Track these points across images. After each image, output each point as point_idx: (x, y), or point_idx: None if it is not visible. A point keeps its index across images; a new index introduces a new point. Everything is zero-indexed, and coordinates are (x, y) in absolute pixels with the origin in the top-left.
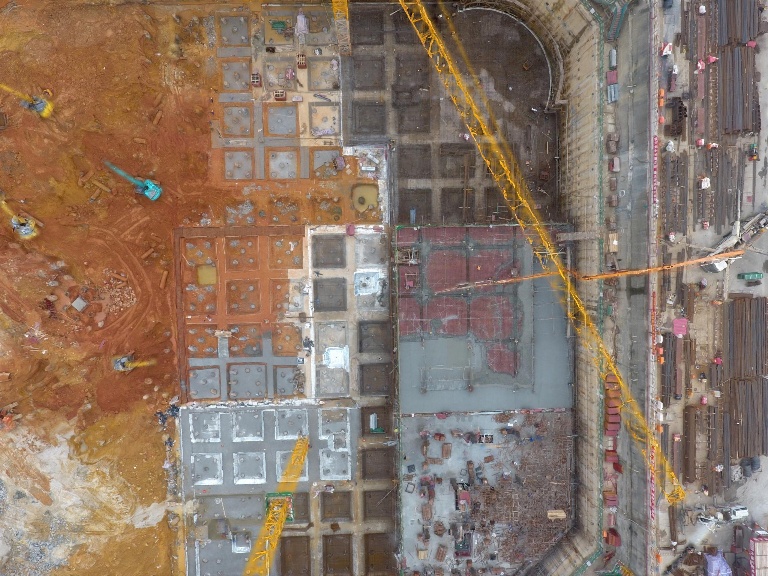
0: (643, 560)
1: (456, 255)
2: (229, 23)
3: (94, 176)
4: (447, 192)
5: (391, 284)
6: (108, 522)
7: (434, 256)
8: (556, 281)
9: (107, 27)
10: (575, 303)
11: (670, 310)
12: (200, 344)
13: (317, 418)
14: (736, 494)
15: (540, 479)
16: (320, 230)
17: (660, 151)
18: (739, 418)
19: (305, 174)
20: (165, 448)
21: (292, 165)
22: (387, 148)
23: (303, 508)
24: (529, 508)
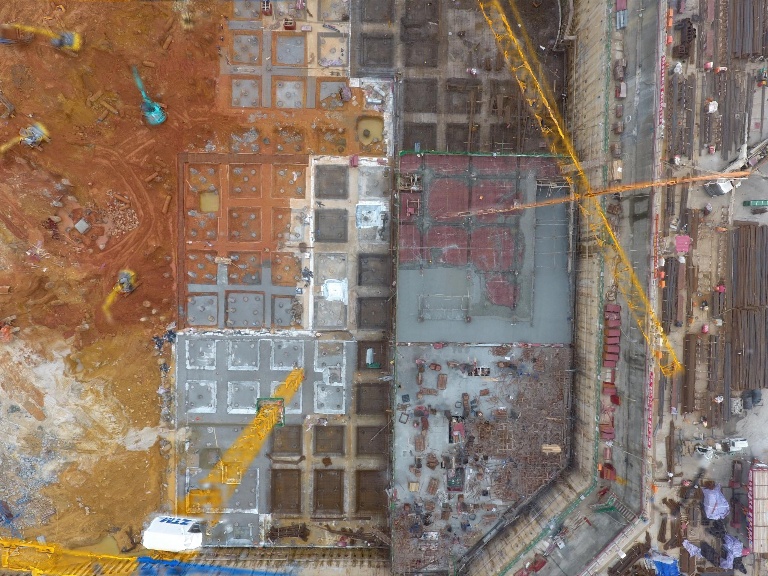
0: (638, 491)
1: (459, 184)
2: None
3: (102, 97)
4: (452, 127)
5: None
6: (100, 441)
7: (436, 184)
8: (559, 216)
9: None
10: (577, 237)
11: (673, 235)
12: (200, 271)
13: (313, 350)
14: (736, 428)
15: (536, 412)
16: (324, 160)
17: (668, 73)
18: (741, 348)
19: (311, 104)
20: (160, 374)
21: (299, 95)
22: (394, 81)
23: (295, 441)
24: (524, 444)
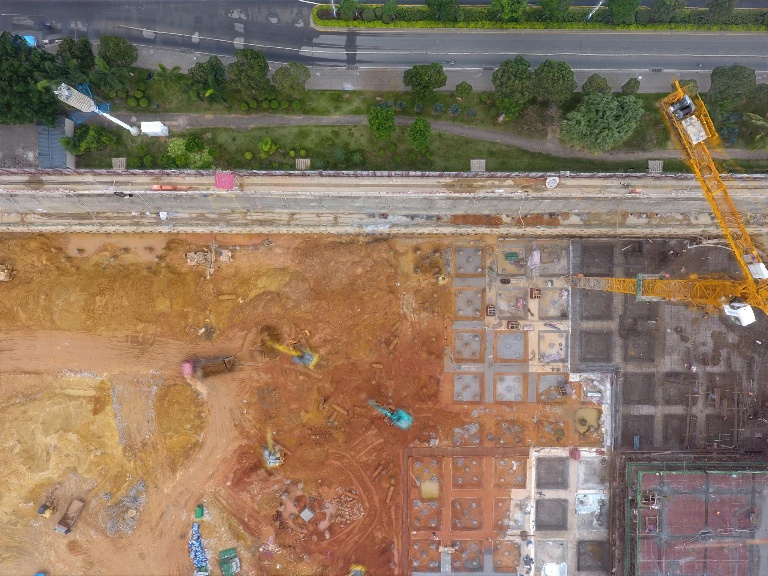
0: None
1: (695, 499)
2: (464, 253)
3: (334, 401)
4: (670, 419)
5: (612, 507)
6: None
7: (674, 500)
8: None
9: (358, 266)
10: None
11: None
12: (422, 557)
13: None
14: None
15: None
16: (544, 452)
17: None
18: None
19: (532, 398)
20: None
21: (518, 388)
22: (613, 376)
23: None
24: None
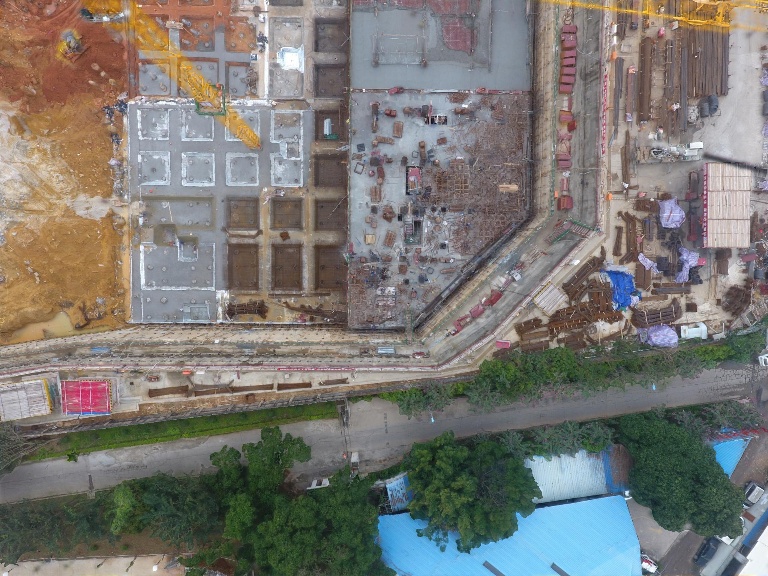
0: (593, 206)
1: None
2: None
3: None
4: None
5: None
6: (48, 202)
7: None
8: None
9: None
10: None
11: None
12: (151, 38)
13: (269, 119)
14: (692, 139)
15: (493, 153)
16: None
17: None
18: (697, 50)
19: None
20: (112, 146)
21: None
22: None
23: (253, 217)
24: (482, 196)
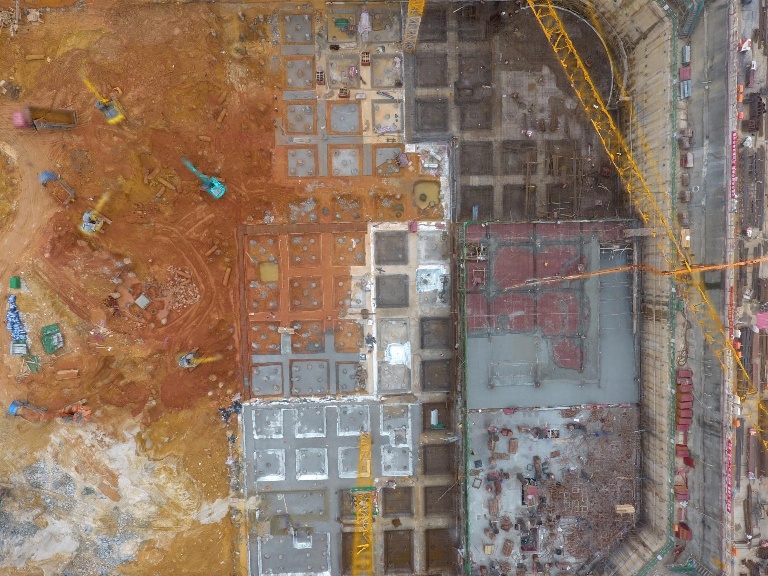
0: (717, 554)
1: (523, 251)
2: (292, 21)
3: (160, 174)
4: (509, 189)
5: (453, 280)
6: (175, 518)
7: (501, 252)
8: (621, 277)
9: (174, 25)
10: (641, 299)
11: (746, 305)
12: (263, 341)
13: (379, 414)
14: None
15: (608, 474)
16: (382, 227)
17: (737, 147)
18: None
19: (368, 171)
20: (228, 444)
21: (354, 162)
22: (450, 145)
23: None
24: (595, 503)
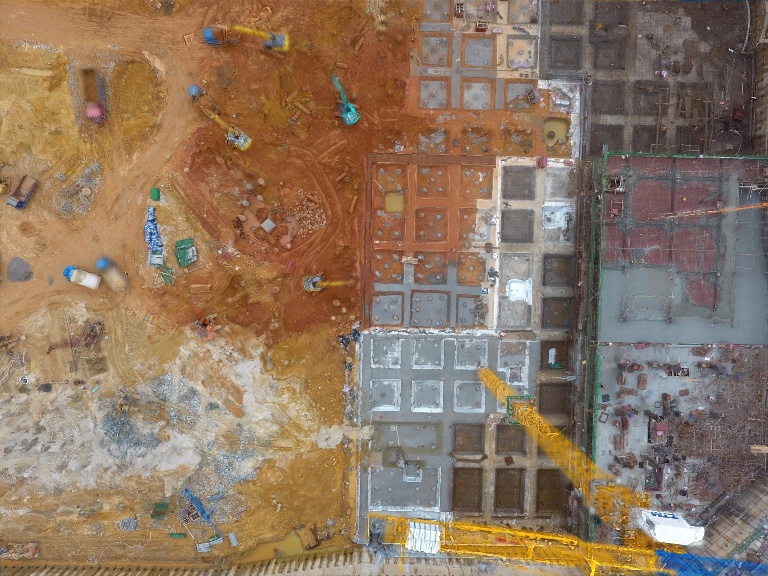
0: None
1: (662, 185)
2: None
3: (297, 97)
4: (640, 129)
5: (579, 218)
6: (295, 439)
7: (640, 185)
8: (756, 218)
9: None
10: None
11: None
12: (385, 270)
13: (497, 349)
14: None
15: (742, 413)
16: (511, 161)
17: None
18: None
19: (500, 105)
20: (344, 372)
21: (486, 96)
22: (583, 82)
23: (477, 440)
24: (722, 445)
